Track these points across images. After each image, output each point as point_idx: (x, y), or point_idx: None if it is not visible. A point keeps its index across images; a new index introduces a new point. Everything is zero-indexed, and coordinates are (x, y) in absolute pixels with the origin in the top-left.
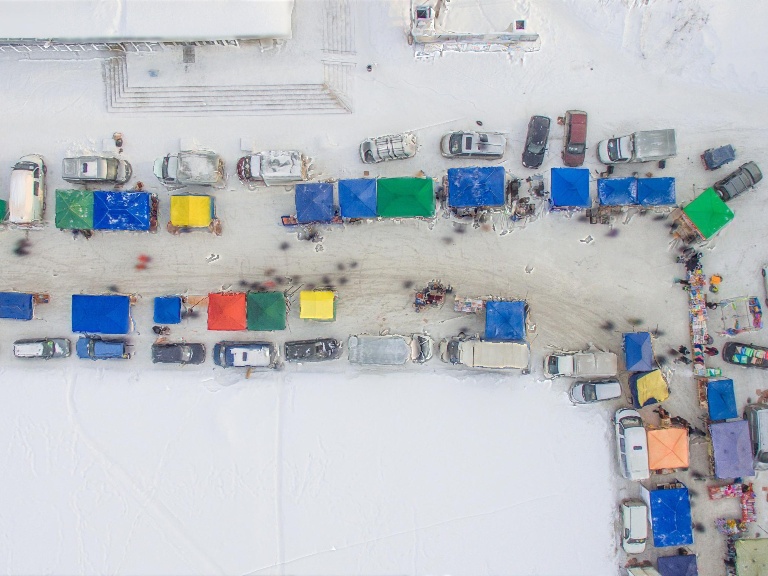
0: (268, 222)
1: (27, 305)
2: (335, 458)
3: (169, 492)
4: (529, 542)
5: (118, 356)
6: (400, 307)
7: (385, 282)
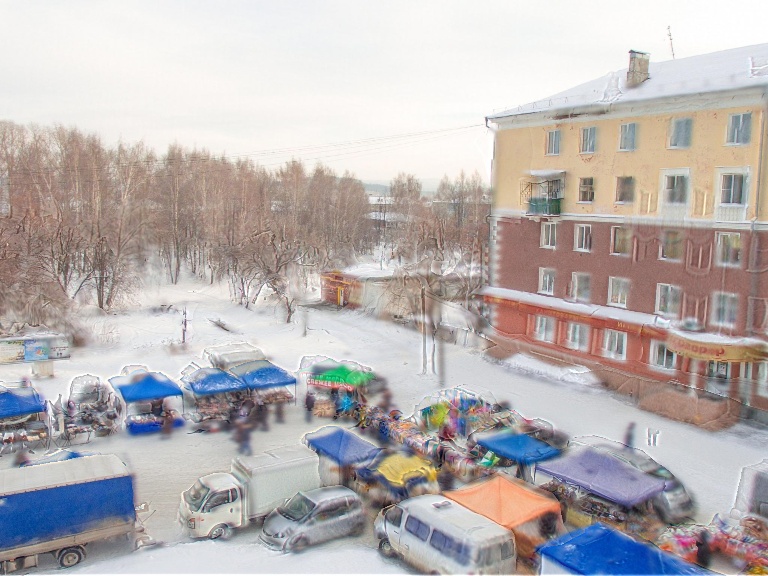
0: None
1: None
2: None
3: None
4: None
5: None
6: None
7: None
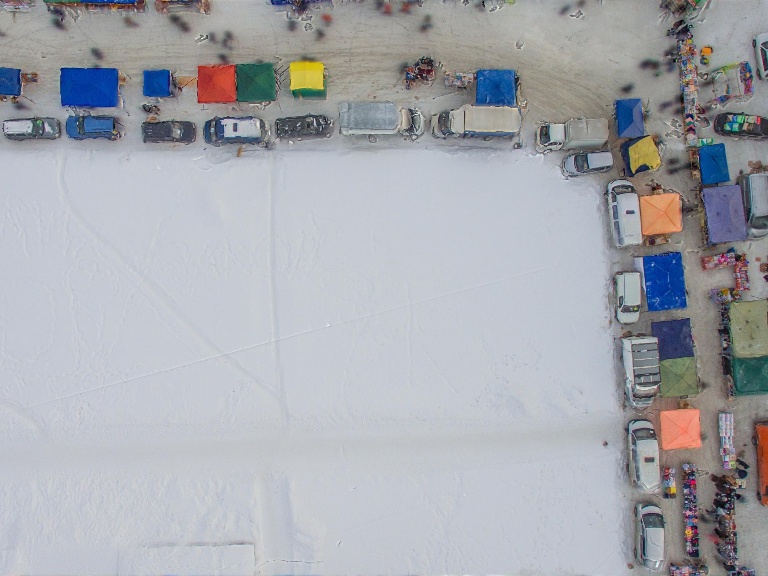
0: (256, 2)
1: (15, 80)
2: (328, 235)
3: (162, 270)
4: (523, 315)
5: (108, 132)
6: (391, 85)
7: (375, 60)
